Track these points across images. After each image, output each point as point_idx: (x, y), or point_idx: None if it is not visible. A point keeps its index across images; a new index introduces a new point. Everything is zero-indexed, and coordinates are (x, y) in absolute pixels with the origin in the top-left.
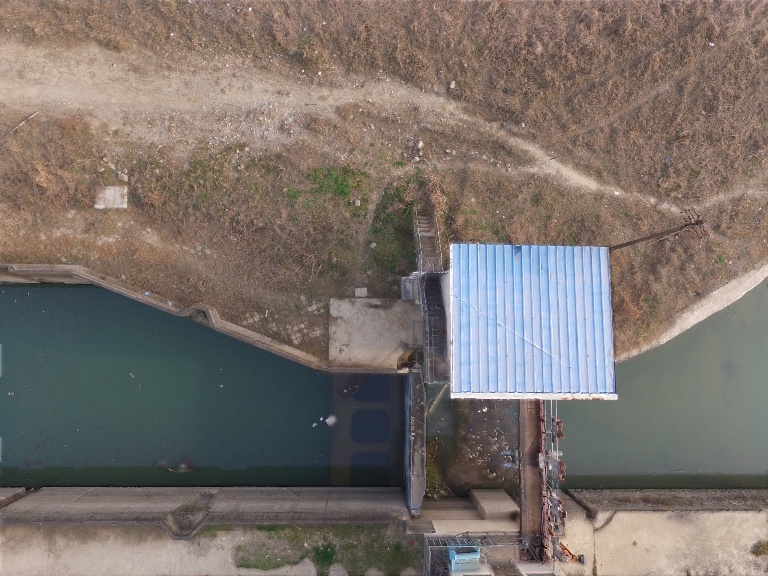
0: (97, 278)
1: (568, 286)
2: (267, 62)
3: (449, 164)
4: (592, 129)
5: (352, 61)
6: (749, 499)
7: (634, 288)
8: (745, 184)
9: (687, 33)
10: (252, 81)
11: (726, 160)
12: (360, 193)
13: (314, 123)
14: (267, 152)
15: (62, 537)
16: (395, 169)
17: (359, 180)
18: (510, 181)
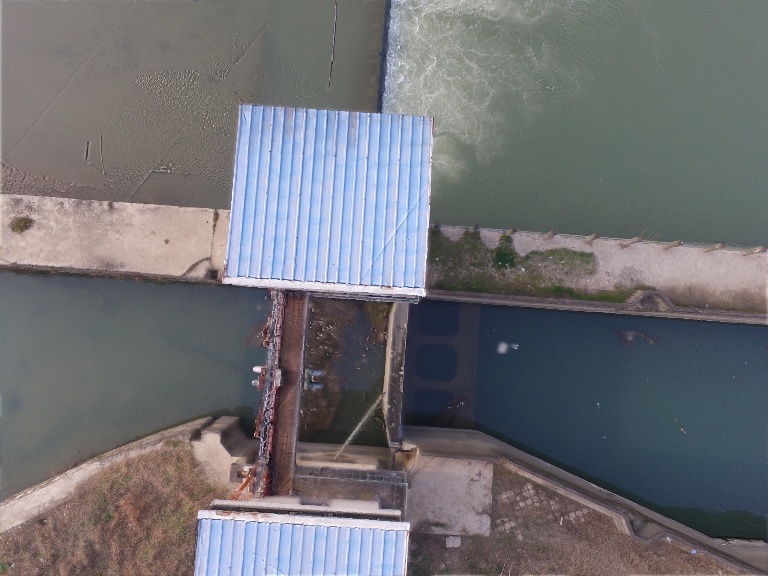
0: (749, 573)
1: None
2: None
3: None
4: None
5: None
6: None
7: (122, 534)
8: None
9: None
10: None
11: None
12: None
13: None
14: None
15: (766, 297)
16: None
17: None
18: None
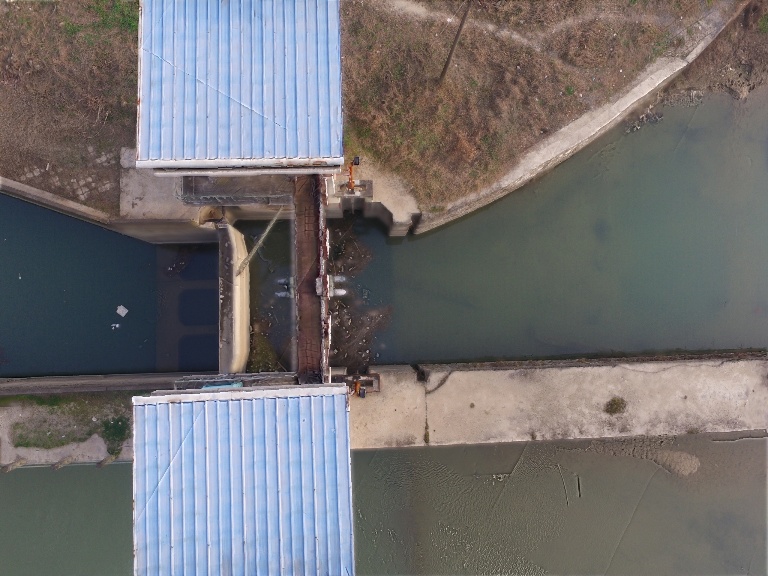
0: None
1: (287, 35)
2: None
3: None
4: None
5: None
6: (611, 361)
7: (471, 126)
8: (596, 7)
9: None
10: None
11: None
12: None
13: None
14: None
15: None
16: None
17: None
18: None
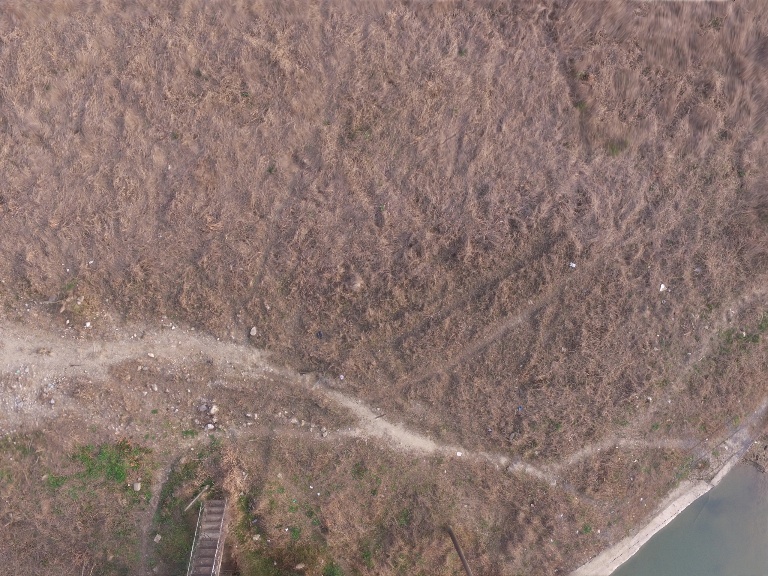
0: None
1: None
2: (23, 312)
3: (251, 431)
4: (427, 377)
5: (128, 307)
6: None
7: (481, 570)
8: (616, 433)
9: (542, 253)
10: (4, 338)
11: (592, 407)
12: (140, 474)
13: (81, 389)
14: (23, 429)
15: None
16: (184, 440)
17: (138, 458)
18: (325, 449)
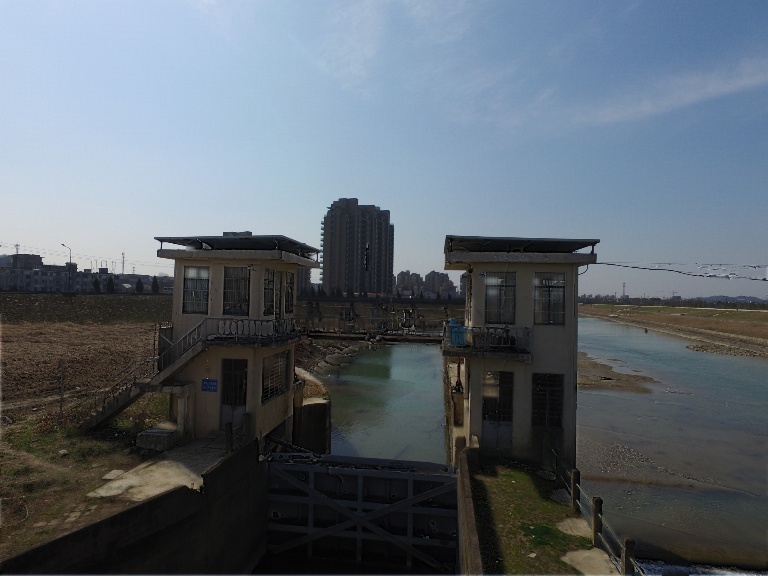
0: None
1: None
2: None
3: None
4: None
5: None
6: None
7: None
8: None
9: None
10: None
11: None
12: None
13: None
14: None
15: None
16: None
17: None
18: None
